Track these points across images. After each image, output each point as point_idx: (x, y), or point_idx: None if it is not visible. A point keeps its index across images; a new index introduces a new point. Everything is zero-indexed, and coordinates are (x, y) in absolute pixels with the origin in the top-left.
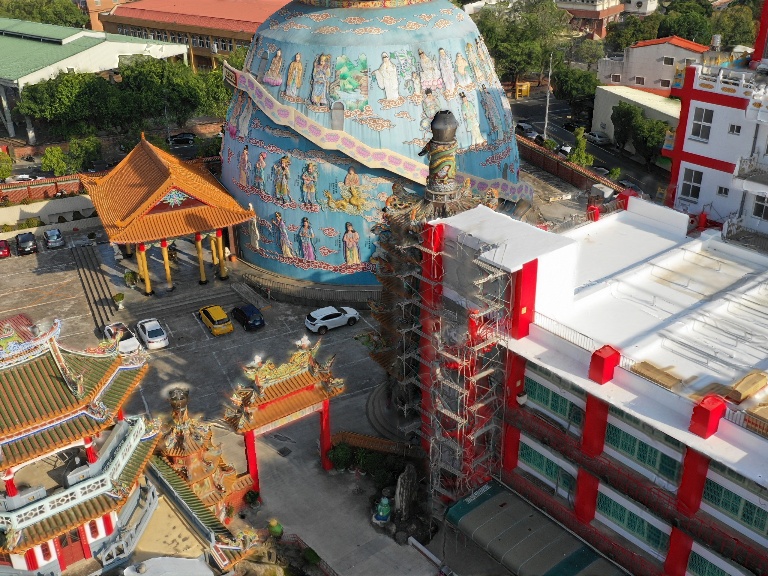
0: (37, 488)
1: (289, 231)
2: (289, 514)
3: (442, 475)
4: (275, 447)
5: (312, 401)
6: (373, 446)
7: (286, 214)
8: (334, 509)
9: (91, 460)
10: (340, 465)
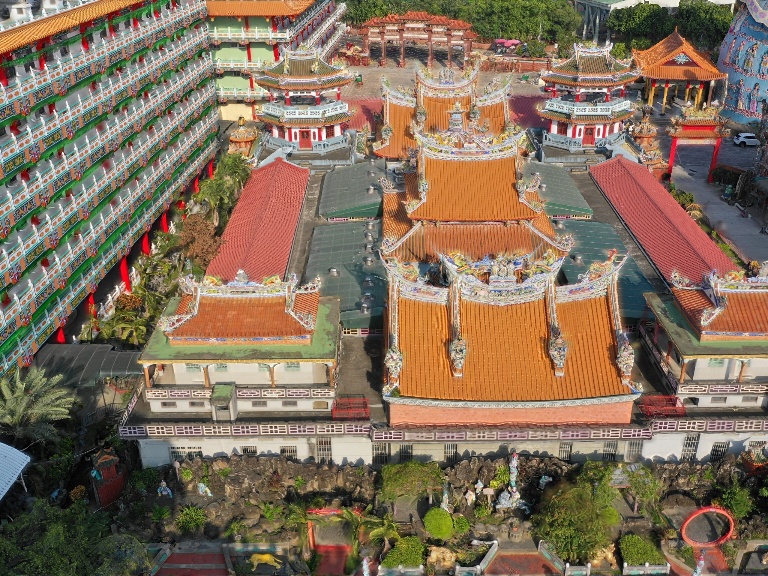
0: (586, 103)
1: (745, 91)
2: (682, 188)
3: (761, 171)
4: (688, 172)
5: (711, 135)
6: (737, 171)
7: (746, 80)
8: (705, 192)
9: (607, 101)
10: (717, 178)
